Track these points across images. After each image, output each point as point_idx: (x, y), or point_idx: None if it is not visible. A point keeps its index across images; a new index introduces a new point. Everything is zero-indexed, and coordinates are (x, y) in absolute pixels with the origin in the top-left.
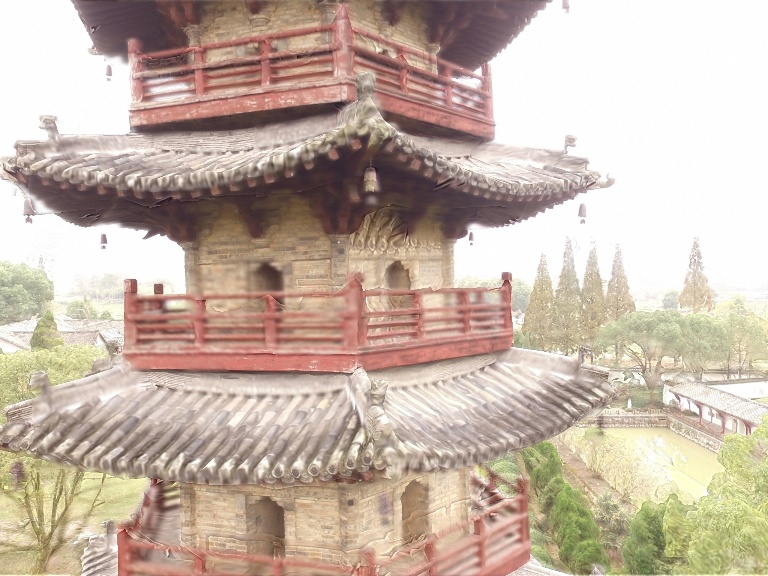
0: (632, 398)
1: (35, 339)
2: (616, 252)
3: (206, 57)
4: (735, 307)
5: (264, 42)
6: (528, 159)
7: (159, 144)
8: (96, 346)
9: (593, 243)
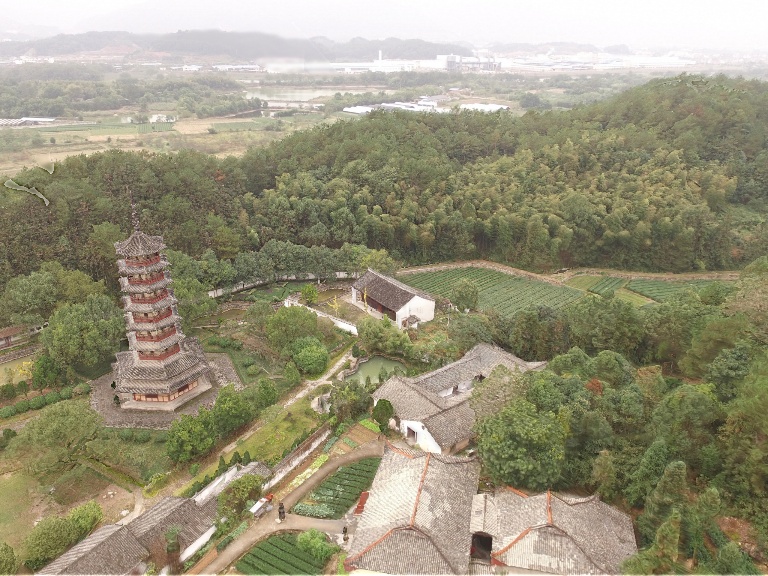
0: None
1: None
2: None
3: None
4: None
5: None
6: None
7: None
8: (47, 410)
9: None
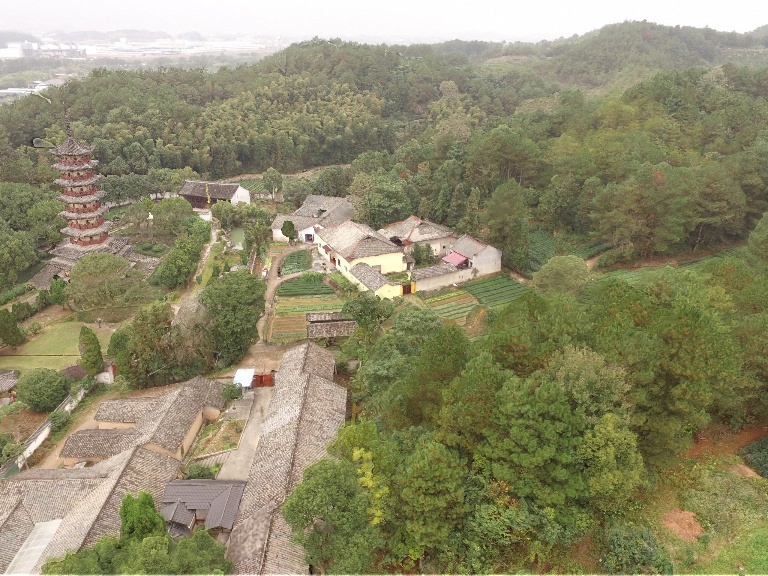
0: None
1: None
2: None
3: None
4: None
5: None
6: None
7: None
8: None
9: None
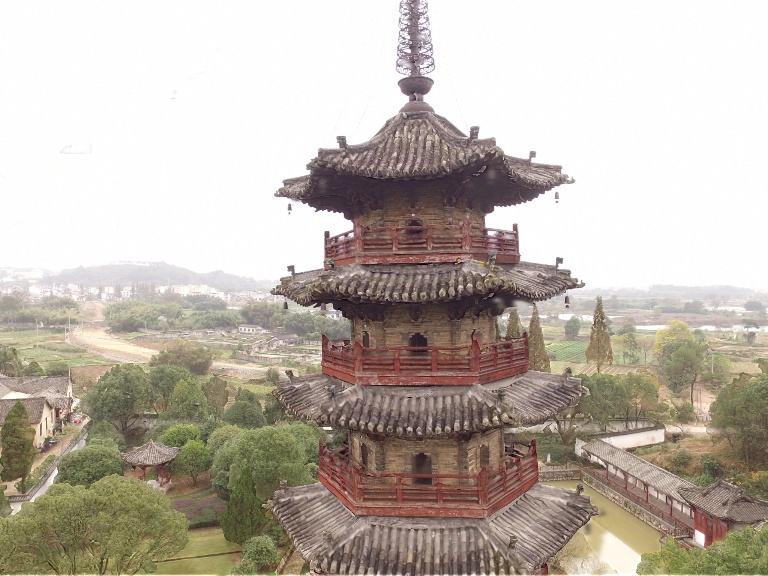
0: (550, 449)
1: (7, 429)
2: (533, 313)
3: (386, 456)
4: (628, 341)
5: (423, 454)
6: (558, 497)
7: (369, 521)
8: (126, 478)
9: None
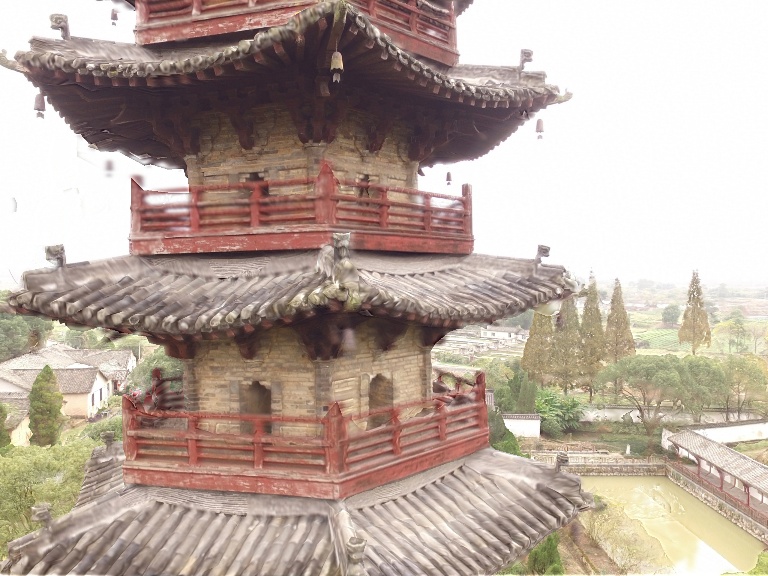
0: (631, 440)
1: (34, 394)
2: (615, 287)
3: (200, 387)
4: (735, 327)
5: (258, 383)
6: (521, 474)
7: (153, 495)
8: (94, 442)
9: (592, 278)
